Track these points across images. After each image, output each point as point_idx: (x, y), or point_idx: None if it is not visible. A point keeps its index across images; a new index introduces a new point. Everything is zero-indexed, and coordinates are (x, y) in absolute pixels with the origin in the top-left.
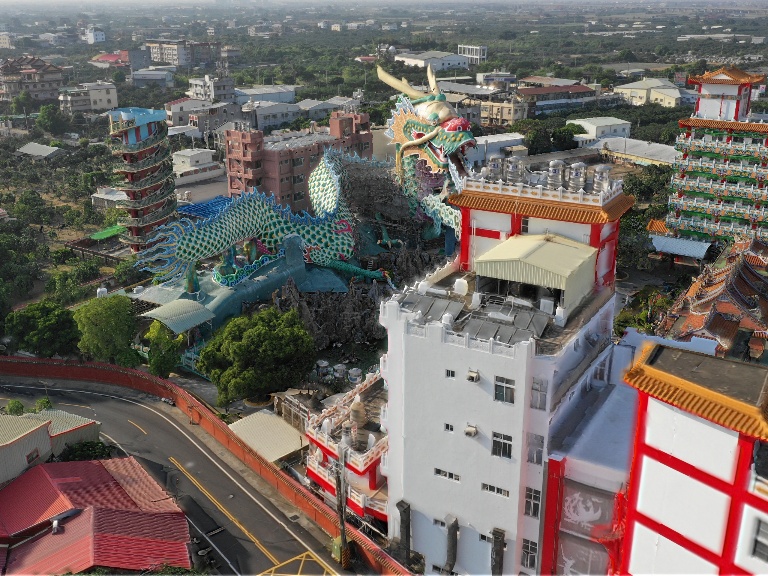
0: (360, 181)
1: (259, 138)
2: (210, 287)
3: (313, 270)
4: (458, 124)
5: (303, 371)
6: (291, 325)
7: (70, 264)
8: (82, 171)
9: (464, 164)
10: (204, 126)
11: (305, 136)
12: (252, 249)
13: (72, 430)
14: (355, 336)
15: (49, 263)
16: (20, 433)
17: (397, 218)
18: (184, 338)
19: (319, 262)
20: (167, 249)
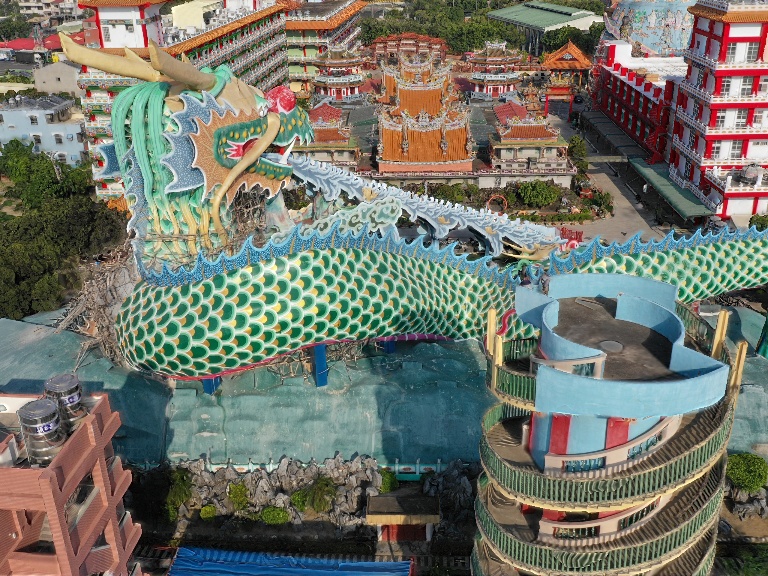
0: None
1: None
2: (732, 354)
3: None
4: None
5: None
6: None
7: None
8: None
9: None
10: None
11: None
12: None
13: None
14: None
15: None
16: None
17: None
18: None
19: None
20: None
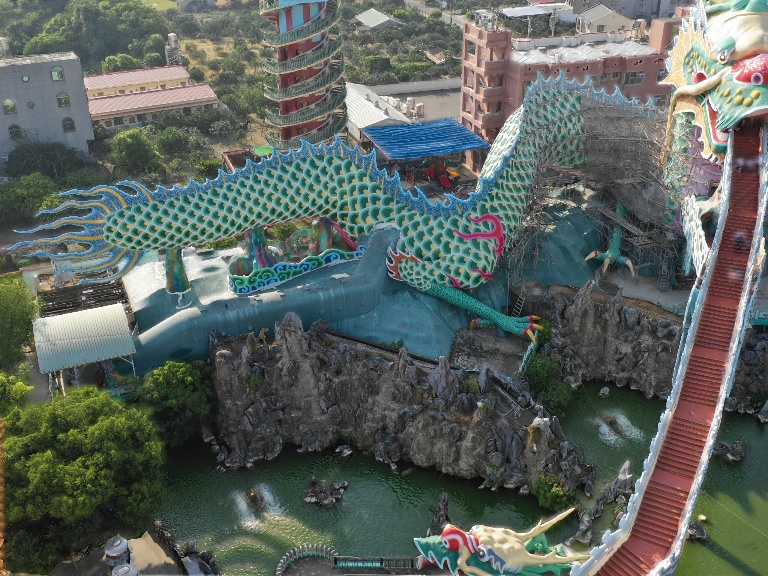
0: (600, 140)
1: (503, 41)
2: (212, 286)
3: (399, 293)
4: (755, 68)
5: (77, 547)
6: (93, 449)
7: None
8: (386, 51)
9: (760, 153)
10: (581, 6)
11: (608, 43)
12: (320, 234)
13: None
14: (376, 446)
15: (194, 175)
16: None
17: (643, 219)
18: (99, 369)
19: (412, 282)
20: (87, 227)
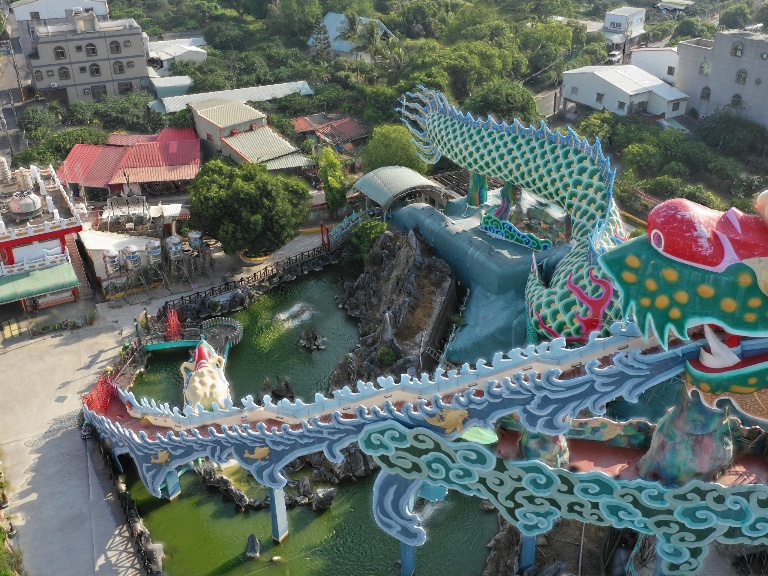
0: None
1: None
2: None
3: (522, 299)
4: None
5: None
6: None
7: (755, 198)
8: None
9: None
10: None
11: None
12: None
13: (236, 150)
14: None
15: None
16: (211, 118)
17: None
18: None
19: None
20: None
